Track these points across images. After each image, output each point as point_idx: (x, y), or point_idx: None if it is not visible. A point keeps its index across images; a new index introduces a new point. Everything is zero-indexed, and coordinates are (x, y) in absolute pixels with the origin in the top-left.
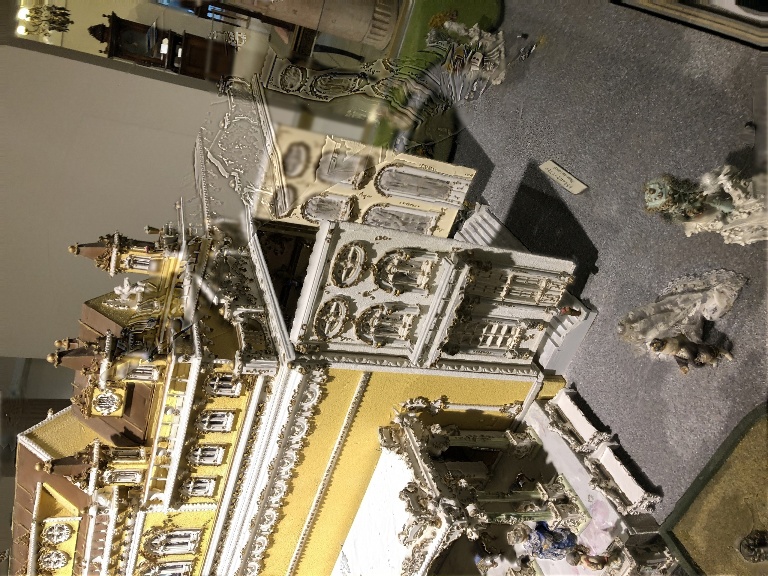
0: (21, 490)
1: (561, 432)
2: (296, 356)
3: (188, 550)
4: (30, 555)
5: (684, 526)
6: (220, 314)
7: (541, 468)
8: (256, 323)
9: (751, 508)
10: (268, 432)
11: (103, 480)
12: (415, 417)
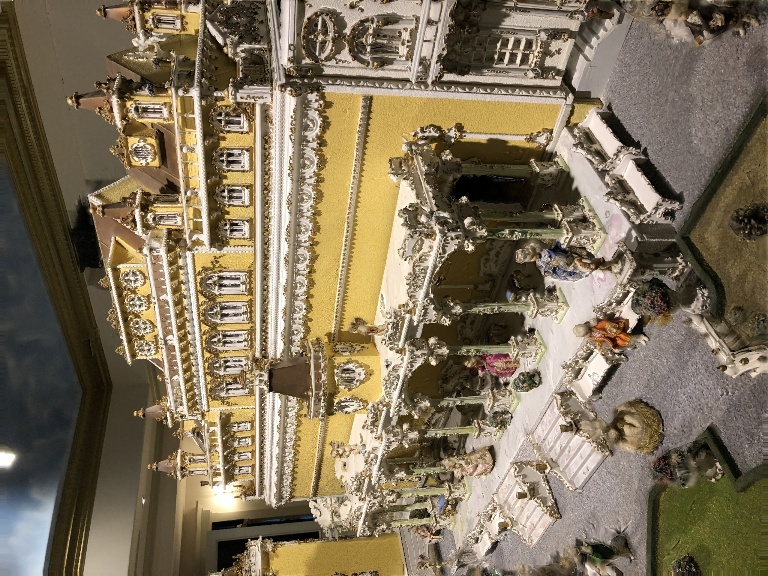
0: (104, 247)
1: (585, 152)
2: (287, 79)
3: (241, 291)
4: (115, 297)
5: (701, 229)
6: (224, 52)
7: (567, 196)
8: (259, 58)
9: (752, 181)
10: (278, 165)
11: (148, 222)
12: (425, 145)
